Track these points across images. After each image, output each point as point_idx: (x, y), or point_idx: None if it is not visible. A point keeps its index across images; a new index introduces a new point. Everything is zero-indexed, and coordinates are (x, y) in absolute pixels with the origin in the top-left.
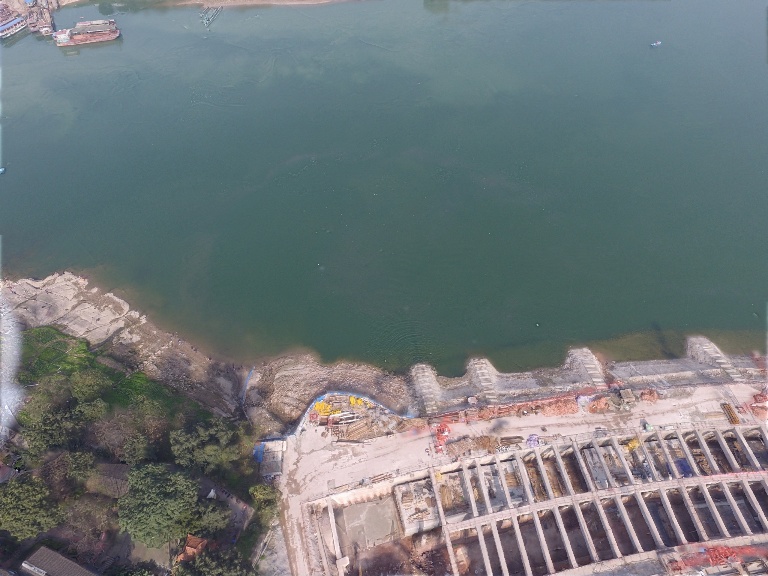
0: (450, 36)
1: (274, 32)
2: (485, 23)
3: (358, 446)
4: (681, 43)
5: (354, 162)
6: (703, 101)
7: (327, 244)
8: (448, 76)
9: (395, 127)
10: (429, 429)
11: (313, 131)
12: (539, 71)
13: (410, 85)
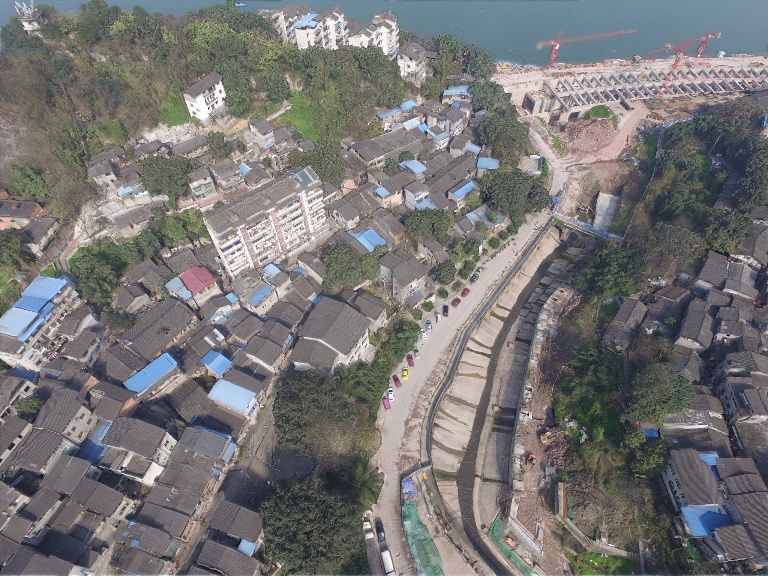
0: None
1: None
2: None
3: (508, 76)
4: None
5: None
6: None
7: (461, 29)
8: None
9: None
10: (541, 71)
11: None
12: None
13: None
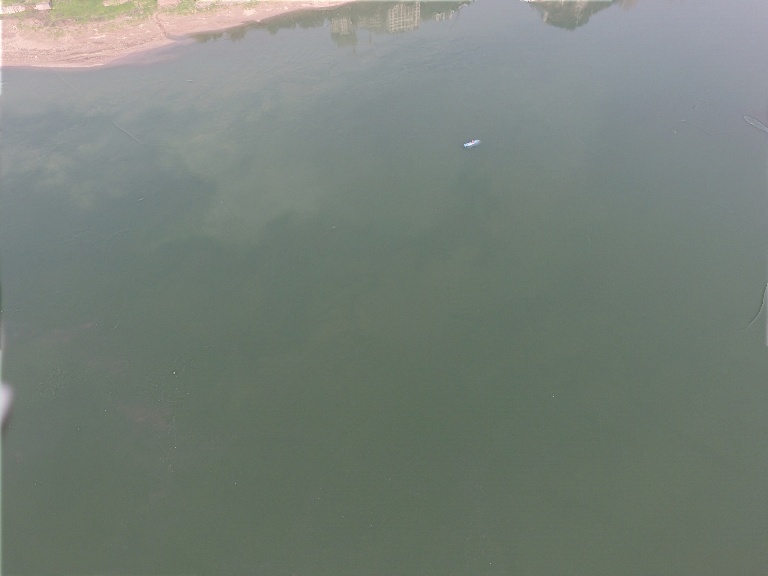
0: (228, 120)
1: (10, 108)
2: (282, 101)
3: None
4: (503, 144)
5: None
6: (491, 246)
7: None
8: (169, 195)
9: (41, 287)
10: None
11: None
12: (306, 183)
13: (128, 201)
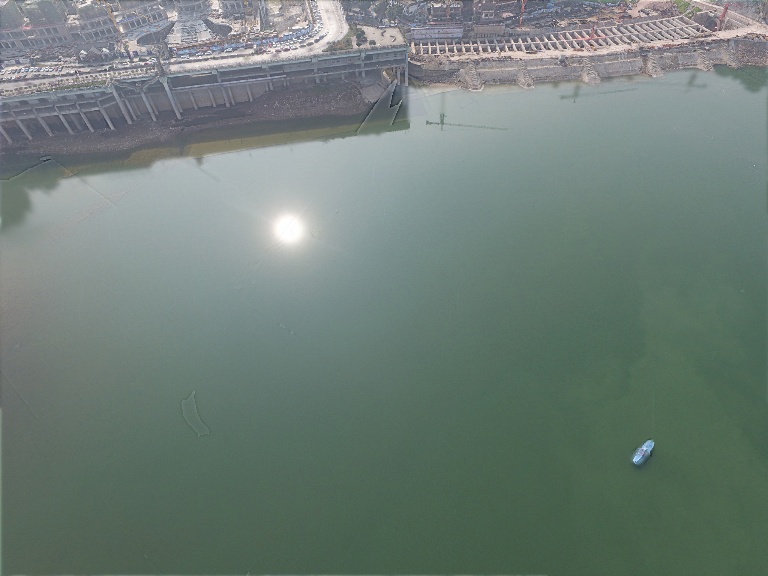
0: None
1: None
2: None
3: None
4: (590, 445)
5: None
6: (565, 273)
7: None
8: None
9: None
10: None
11: None
12: None
13: None
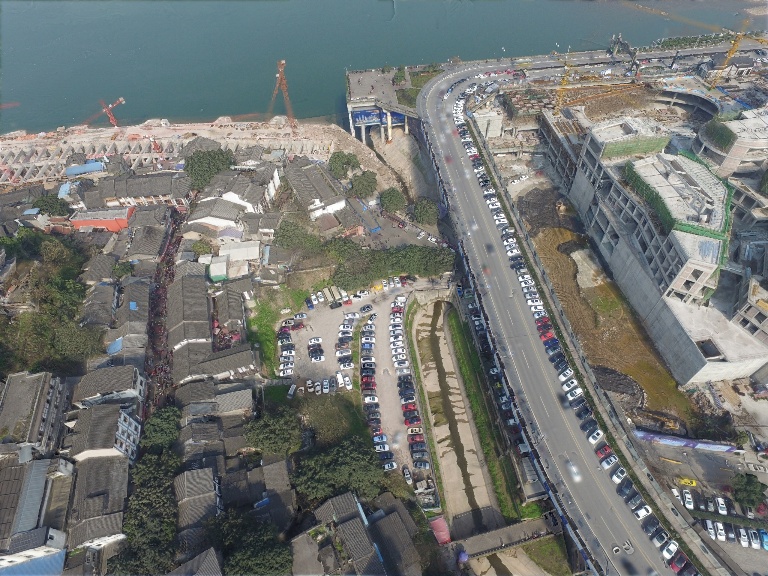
0: None
1: None
2: None
3: None
4: None
5: (37, 50)
6: (304, 12)
7: None
8: None
9: (78, 30)
10: None
11: (28, 36)
12: None
13: None
